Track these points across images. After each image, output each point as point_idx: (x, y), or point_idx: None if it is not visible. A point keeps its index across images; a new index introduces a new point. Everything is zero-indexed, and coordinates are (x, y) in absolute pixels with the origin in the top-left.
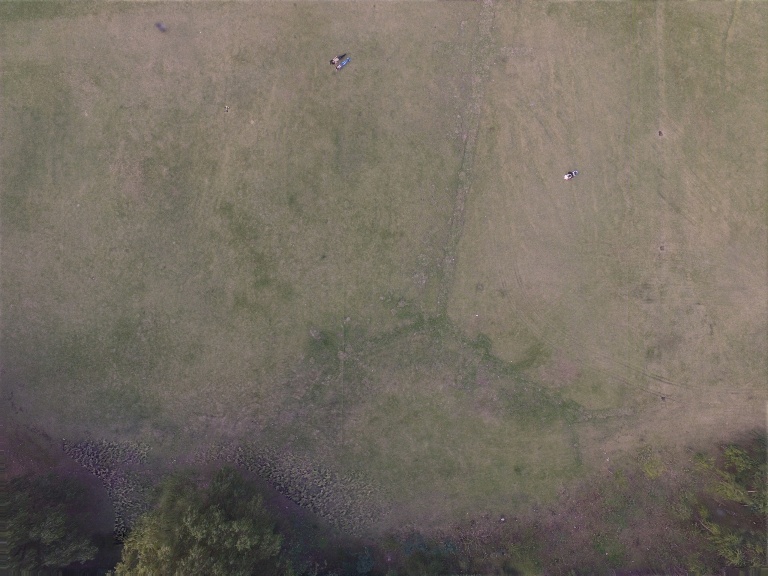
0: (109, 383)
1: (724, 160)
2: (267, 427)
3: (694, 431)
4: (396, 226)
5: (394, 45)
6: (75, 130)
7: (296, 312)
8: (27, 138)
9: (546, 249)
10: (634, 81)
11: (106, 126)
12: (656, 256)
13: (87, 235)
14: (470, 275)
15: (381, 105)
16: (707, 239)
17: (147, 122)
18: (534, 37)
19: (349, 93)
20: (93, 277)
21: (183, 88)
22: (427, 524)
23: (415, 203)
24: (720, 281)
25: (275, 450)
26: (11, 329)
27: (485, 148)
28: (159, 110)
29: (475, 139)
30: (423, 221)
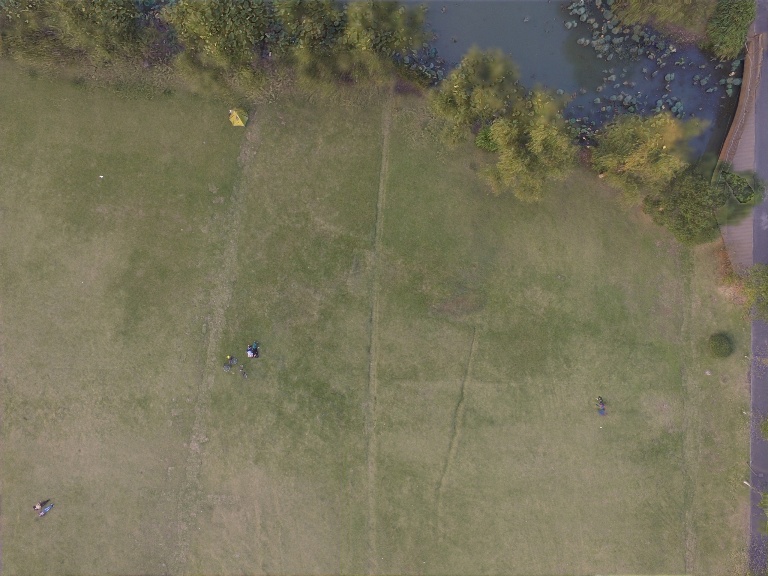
0: None
1: None
2: None
3: None
4: None
5: (99, 490)
6: None
7: None
8: None
9: None
10: (344, 530)
11: None
12: None
13: None
14: None
15: (85, 553)
16: None
17: None
18: (241, 485)
19: (52, 540)
20: None
21: None
22: None
23: None
24: None
25: None
26: None
27: None
28: None
29: None
30: None
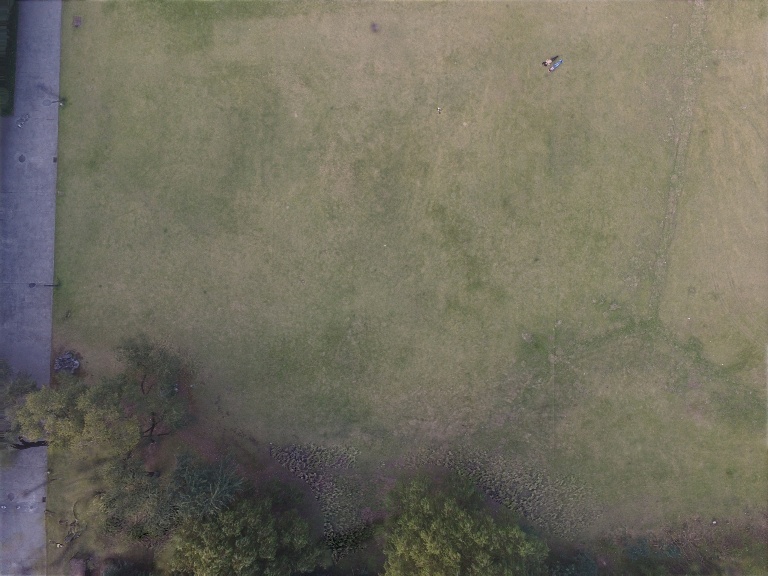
0: (318, 387)
1: None
2: (478, 431)
3: None
4: (609, 229)
5: (606, 47)
6: (284, 131)
7: (508, 315)
8: (235, 139)
9: (758, 252)
10: None
11: (316, 127)
12: None
13: (296, 237)
14: (682, 278)
15: (594, 107)
16: None
17: (358, 123)
18: (746, 40)
19: (562, 95)
20: (302, 280)
21: (394, 89)
22: (638, 527)
23: (628, 206)
24: None
25: (486, 454)
26: (219, 332)
27: (697, 151)
28: (370, 111)
29: (687, 142)
30: (635, 224)
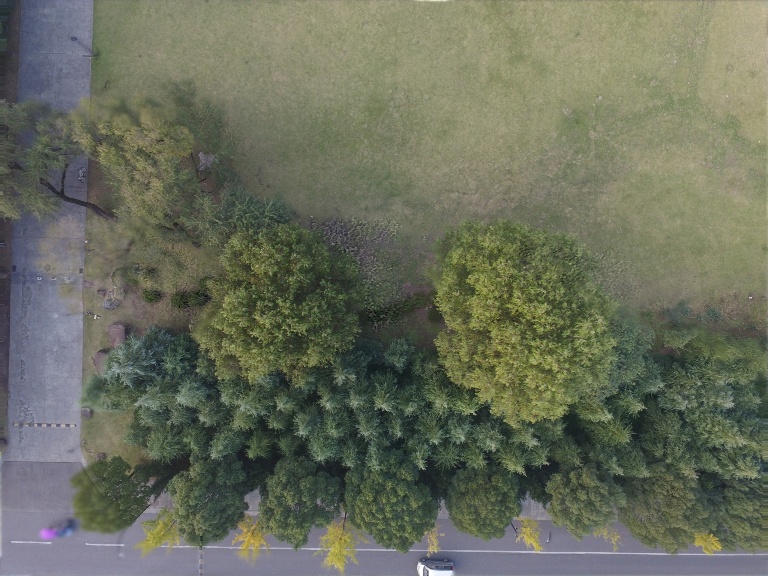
0: (360, 159)
1: None
2: (518, 205)
3: None
4: (649, 5)
5: None
6: None
7: (549, 89)
8: None
9: None
10: None
11: None
12: None
13: (339, 9)
14: (721, 56)
15: None
16: None
17: None
18: None
19: None
20: (345, 51)
21: None
22: (676, 302)
23: None
24: None
25: (526, 228)
26: (260, 103)
27: None
28: None
29: None
30: (675, 1)
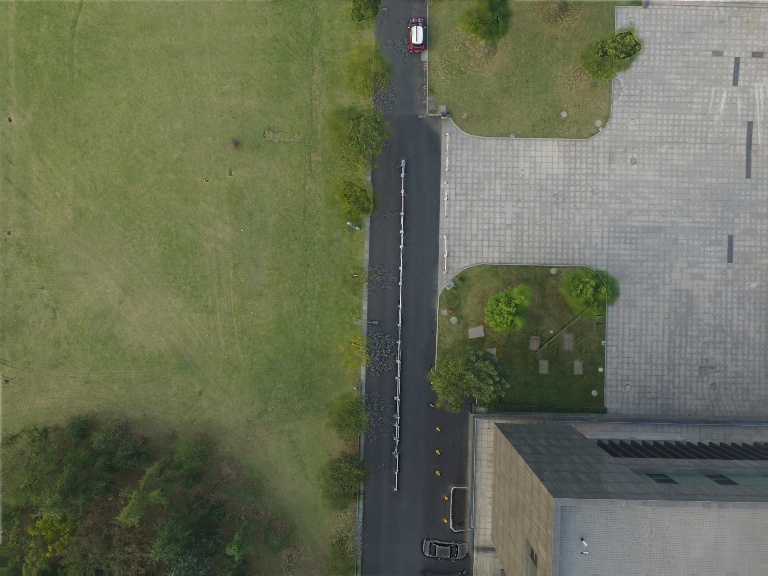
0: None
1: (70, 146)
2: None
3: (32, 414)
4: None
5: None
6: None
7: None
8: None
9: None
10: None
11: None
12: (2, 241)
13: None
14: None
15: None
16: (51, 224)
17: None
18: None
19: None
20: None
21: None
22: None
23: None
24: (63, 266)
25: None
26: None
27: None
28: None
29: None
30: None
